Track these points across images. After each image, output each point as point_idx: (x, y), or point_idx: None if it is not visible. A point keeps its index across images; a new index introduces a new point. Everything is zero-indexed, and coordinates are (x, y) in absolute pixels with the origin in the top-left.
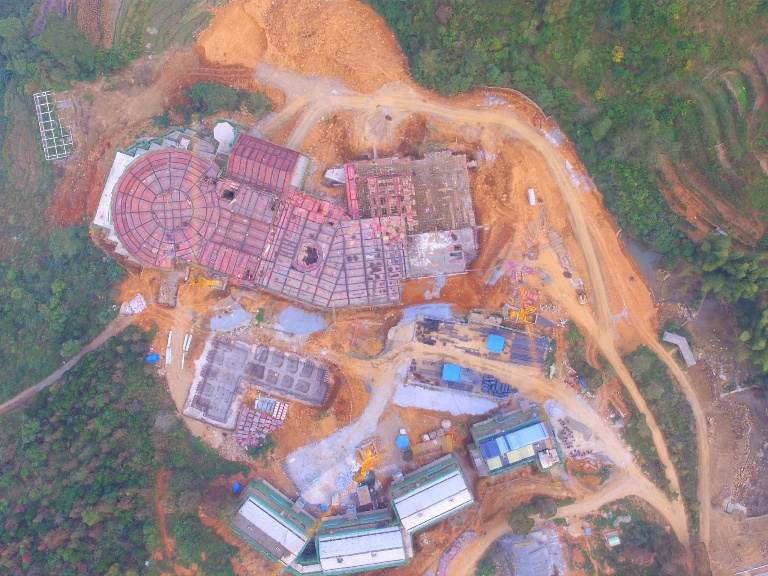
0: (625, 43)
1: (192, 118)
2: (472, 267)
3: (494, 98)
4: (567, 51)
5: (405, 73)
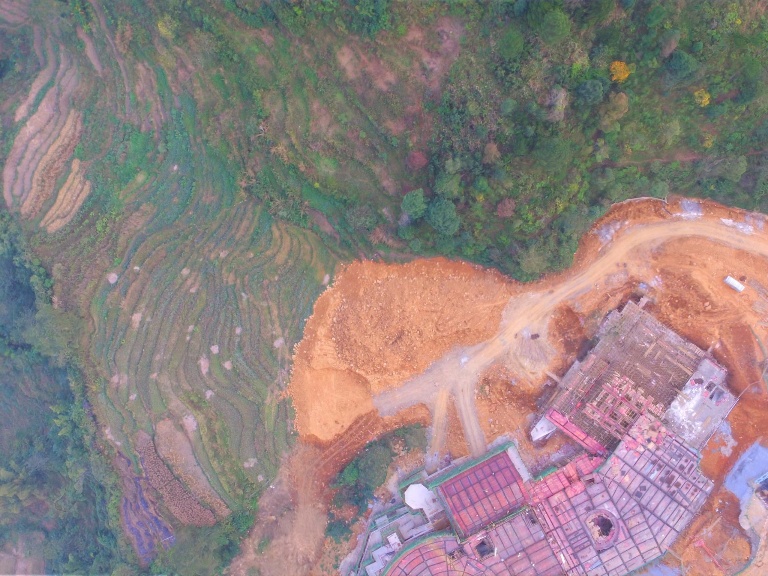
0: (702, 84)
1: (360, 500)
2: (735, 389)
3: (605, 230)
4: (644, 135)
5: (509, 285)
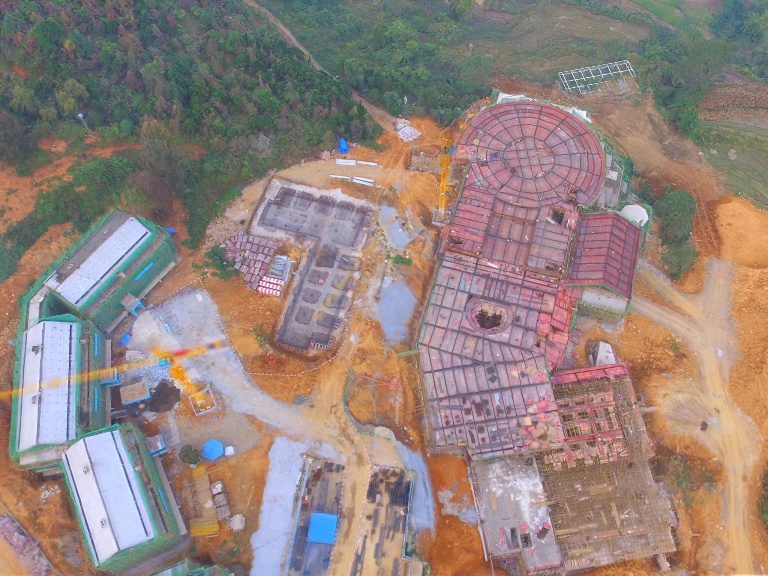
0: None
1: (639, 197)
2: (497, 569)
3: None
4: None
5: None
